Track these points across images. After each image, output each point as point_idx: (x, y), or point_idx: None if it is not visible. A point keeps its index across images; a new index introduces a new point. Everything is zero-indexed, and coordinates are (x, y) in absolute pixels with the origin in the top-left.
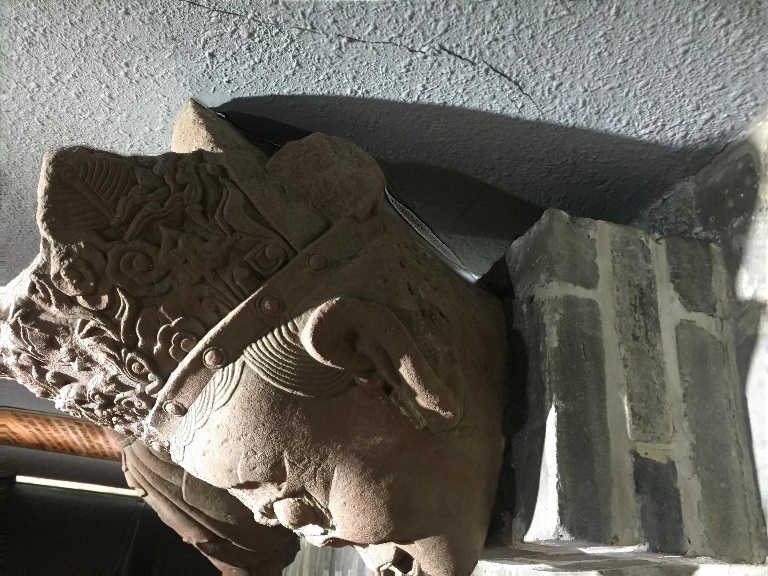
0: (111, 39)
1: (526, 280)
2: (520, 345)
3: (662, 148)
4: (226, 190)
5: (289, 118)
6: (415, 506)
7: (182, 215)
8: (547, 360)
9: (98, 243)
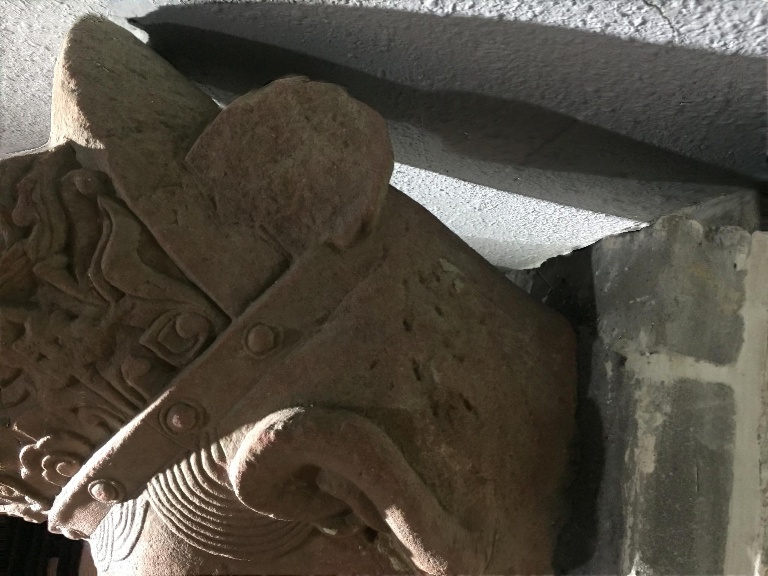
0: None
1: (617, 320)
2: (595, 429)
3: None
4: (108, 221)
5: (254, 32)
6: None
7: (31, 278)
8: (633, 488)
9: None
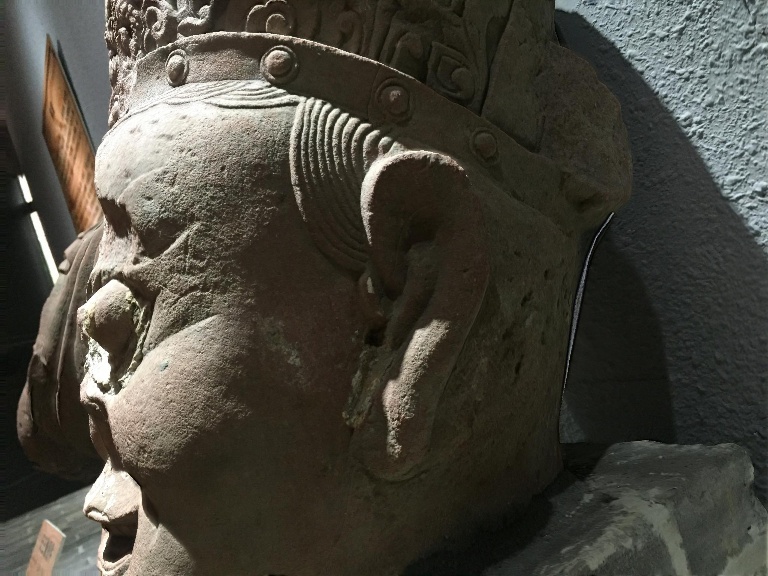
0: None
1: (622, 479)
2: (537, 522)
3: None
4: None
5: None
6: (220, 483)
7: None
8: (560, 568)
9: None
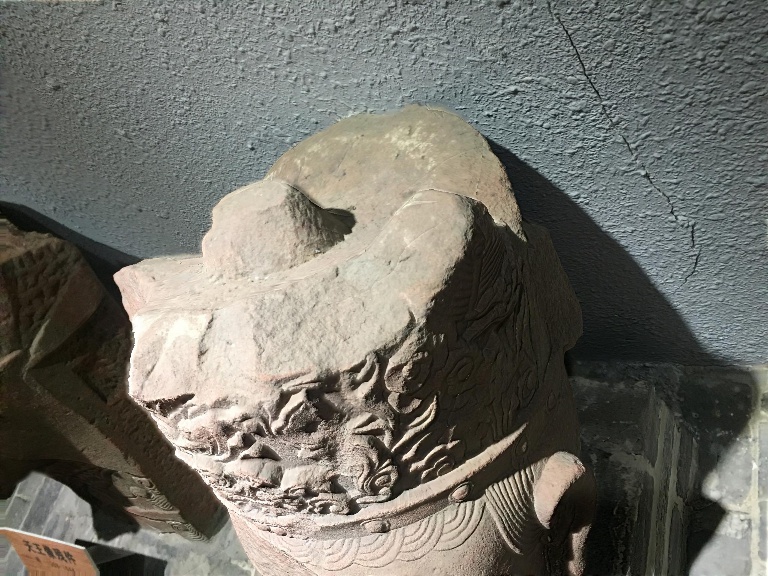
0: (441, 3)
1: (599, 430)
2: None
3: (697, 347)
4: (524, 294)
5: None
6: None
7: (504, 320)
8: (625, 529)
9: (453, 339)
